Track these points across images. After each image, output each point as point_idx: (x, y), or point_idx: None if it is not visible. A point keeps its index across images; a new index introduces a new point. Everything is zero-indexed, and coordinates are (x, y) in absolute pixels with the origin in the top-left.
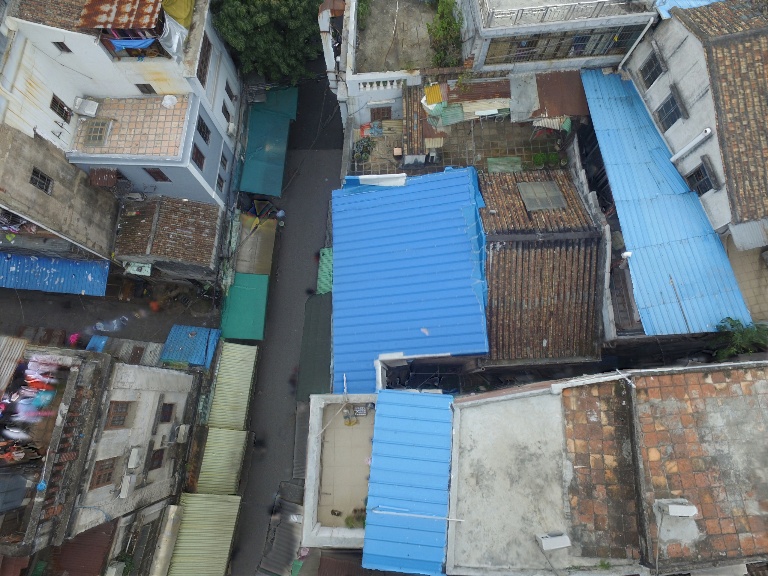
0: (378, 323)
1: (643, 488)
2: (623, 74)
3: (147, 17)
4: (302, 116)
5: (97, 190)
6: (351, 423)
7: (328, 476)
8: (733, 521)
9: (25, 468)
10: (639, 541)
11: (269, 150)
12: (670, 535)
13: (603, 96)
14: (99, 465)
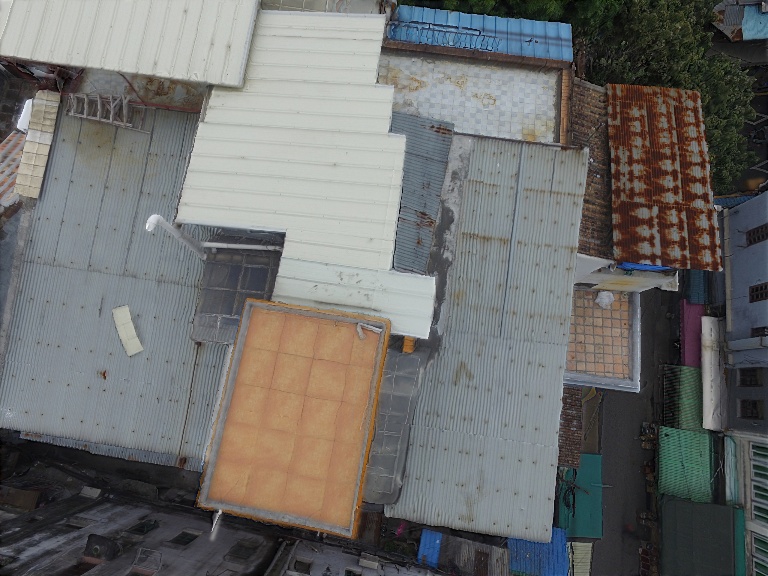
0: None
1: None
2: None
3: (707, 253)
4: None
5: None
6: None
7: None
8: None
9: None
10: None
11: None
12: None
13: None
14: None
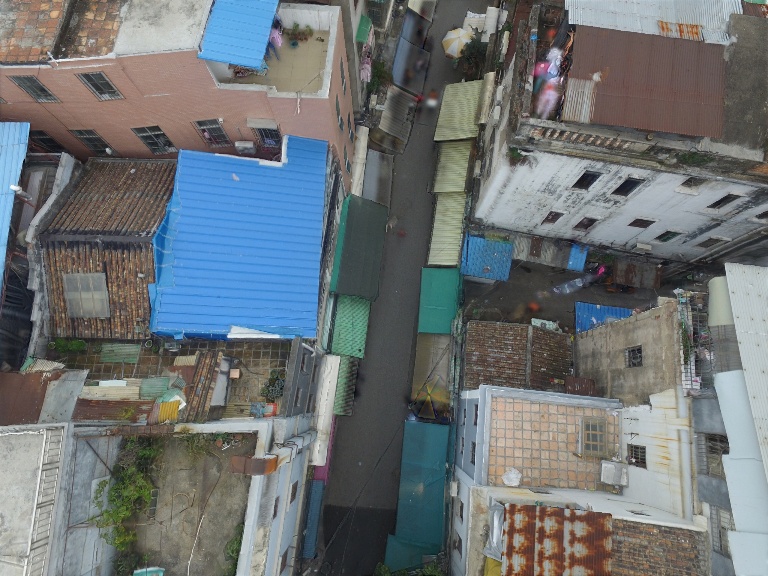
0: (280, 193)
1: None
2: None
3: (518, 525)
4: None
5: None
6: None
7: (325, 62)
8: None
9: (550, 50)
10: None
11: (419, 484)
12: None
13: None
14: None
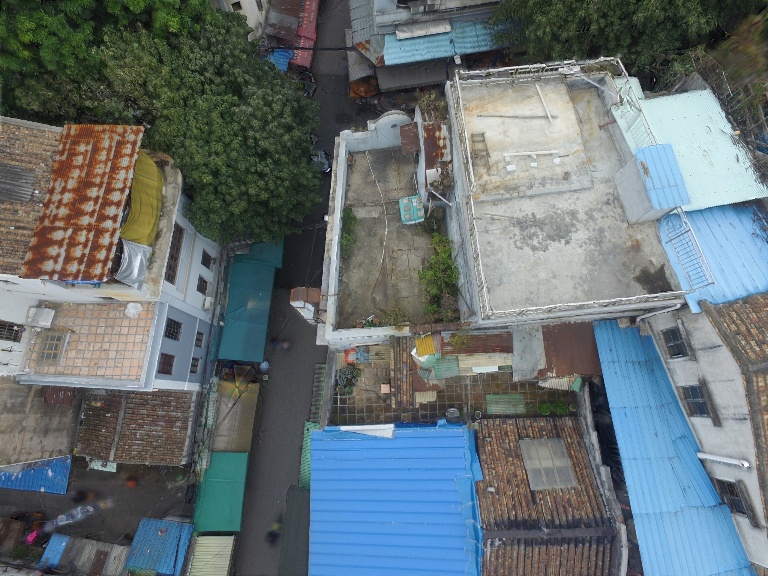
0: None
1: None
2: (642, 327)
3: (99, 266)
4: (290, 249)
5: None
6: None
7: None
8: None
9: None
10: None
11: (251, 307)
12: None
13: (619, 358)
14: None
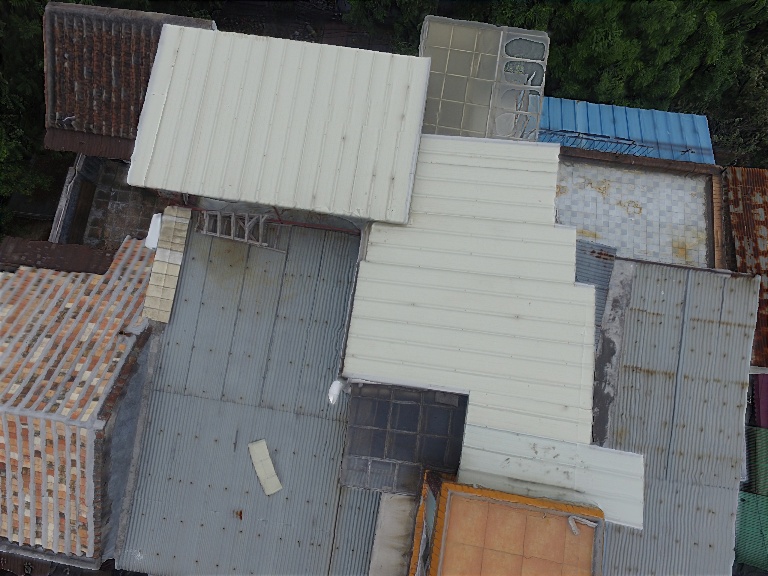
0: None
1: None
2: None
3: None
4: None
5: None
6: None
7: None
8: None
9: None
10: None
11: None
12: None
13: None
14: None
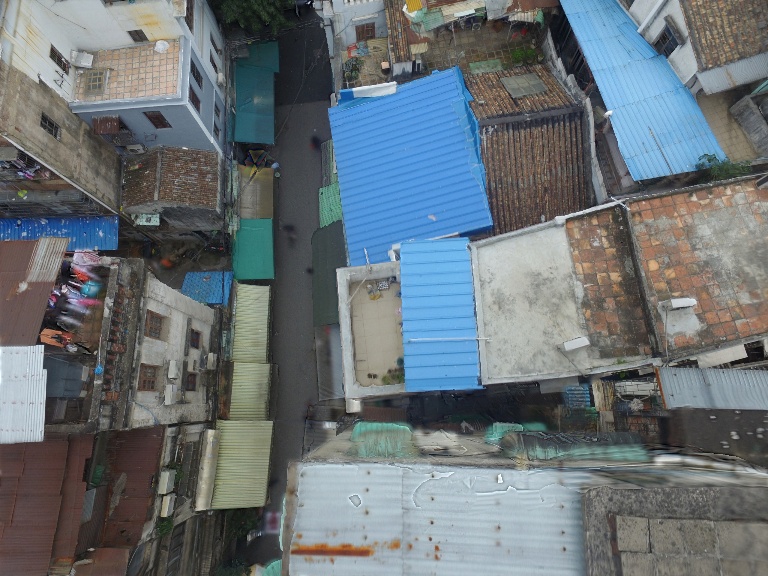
0: (387, 218)
1: (647, 292)
2: None
3: None
4: (284, 74)
5: (100, 143)
6: (376, 297)
7: (360, 345)
8: (729, 311)
9: (81, 357)
10: (649, 340)
11: (258, 102)
12: (675, 329)
13: None
14: (143, 370)
